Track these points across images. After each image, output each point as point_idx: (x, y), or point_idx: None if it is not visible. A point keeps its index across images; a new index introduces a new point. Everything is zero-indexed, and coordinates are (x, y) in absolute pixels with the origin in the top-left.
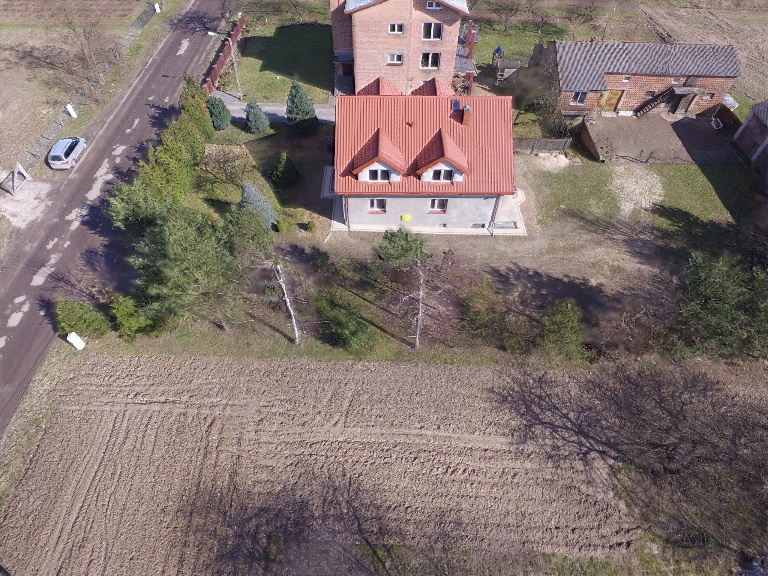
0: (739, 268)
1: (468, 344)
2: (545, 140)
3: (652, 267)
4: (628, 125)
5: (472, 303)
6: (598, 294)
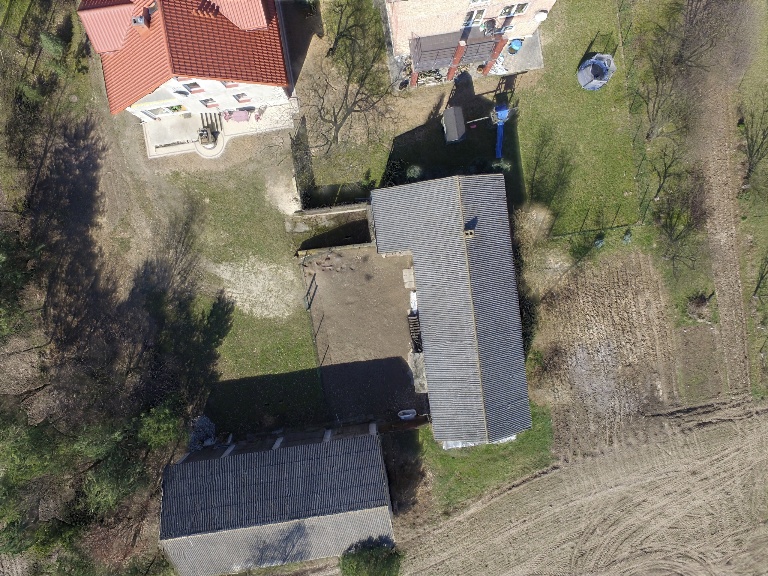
0: (155, 364)
1: (5, 103)
2: (297, 178)
3: (136, 280)
4: (390, 301)
5: (47, 104)
6: (88, 222)
